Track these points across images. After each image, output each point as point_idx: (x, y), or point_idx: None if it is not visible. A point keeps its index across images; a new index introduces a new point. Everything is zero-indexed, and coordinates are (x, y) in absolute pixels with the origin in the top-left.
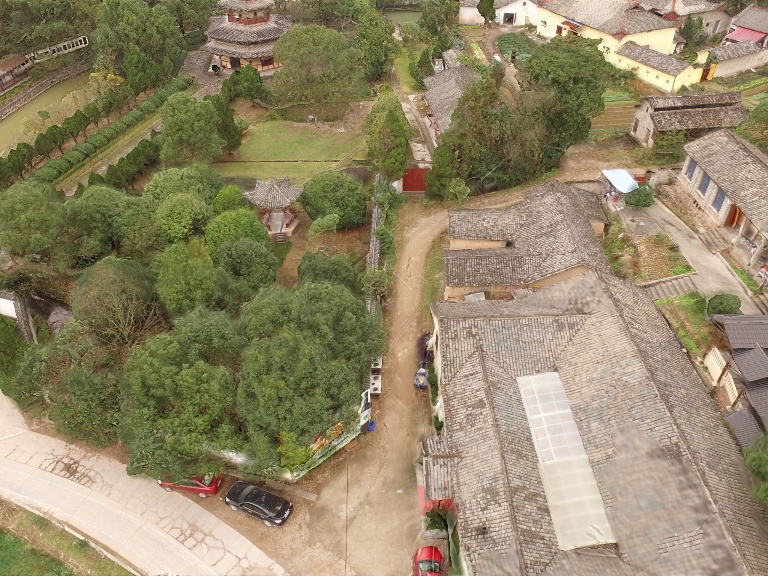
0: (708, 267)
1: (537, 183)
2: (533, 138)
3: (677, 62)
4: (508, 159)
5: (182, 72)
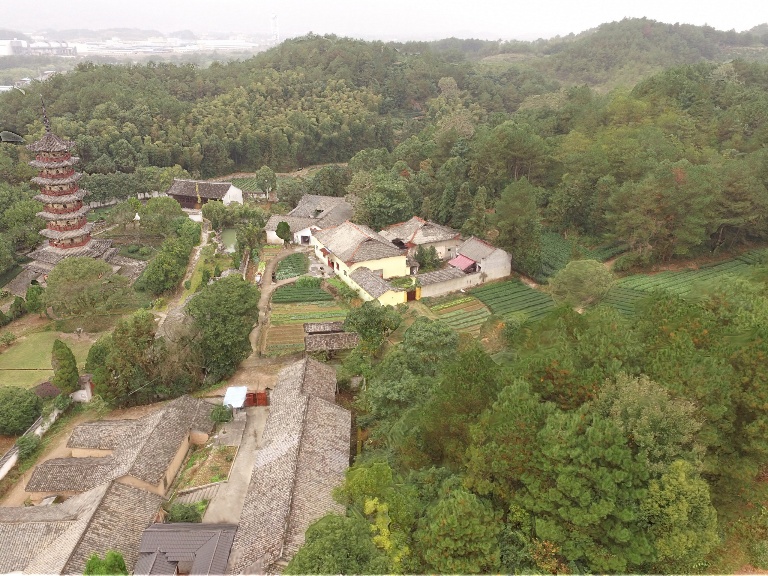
0: (242, 476)
1: (201, 394)
2: (184, 359)
3: (382, 287)
4: (161, 376)
5: (9, 285)
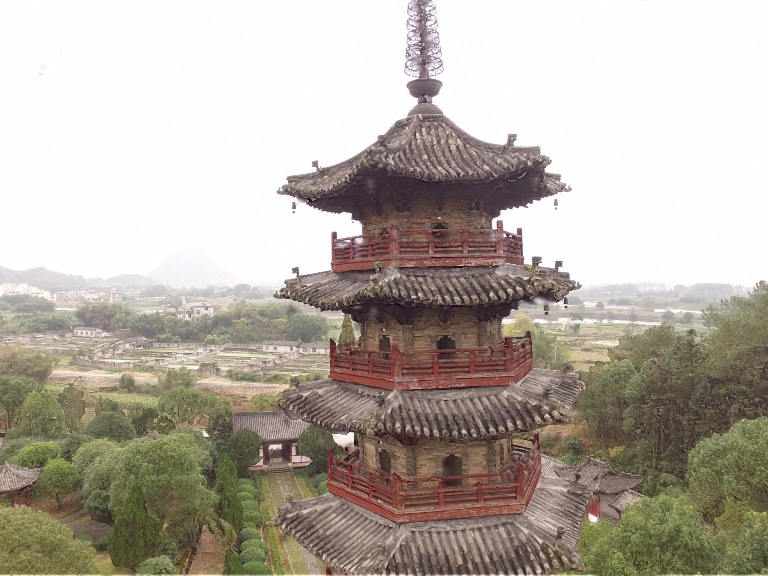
0: None
1: None
2: None
3: None
4: None
5: None
